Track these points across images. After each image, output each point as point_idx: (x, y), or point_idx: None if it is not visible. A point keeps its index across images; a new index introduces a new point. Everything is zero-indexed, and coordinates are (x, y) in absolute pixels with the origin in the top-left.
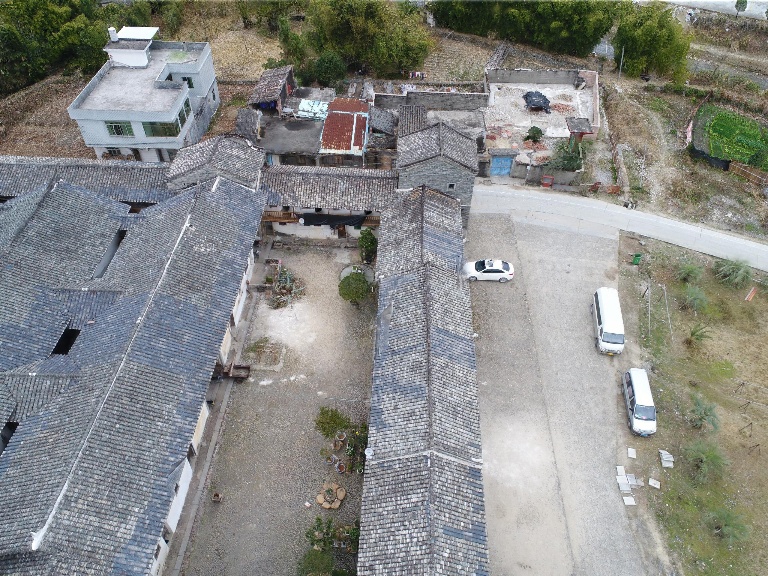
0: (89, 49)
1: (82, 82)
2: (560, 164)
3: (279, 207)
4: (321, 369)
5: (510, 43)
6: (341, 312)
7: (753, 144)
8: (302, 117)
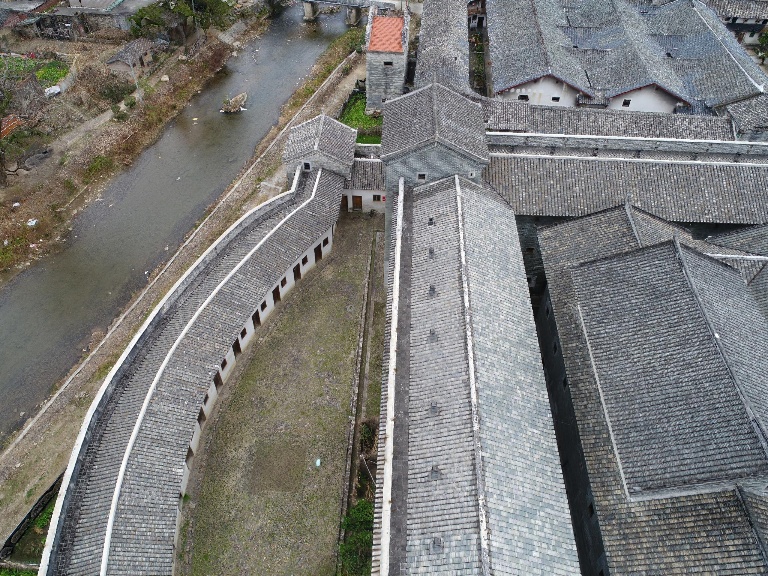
0: None
1: None
2: None
3: None
4: None
5: None
6: None
7: None
8: None
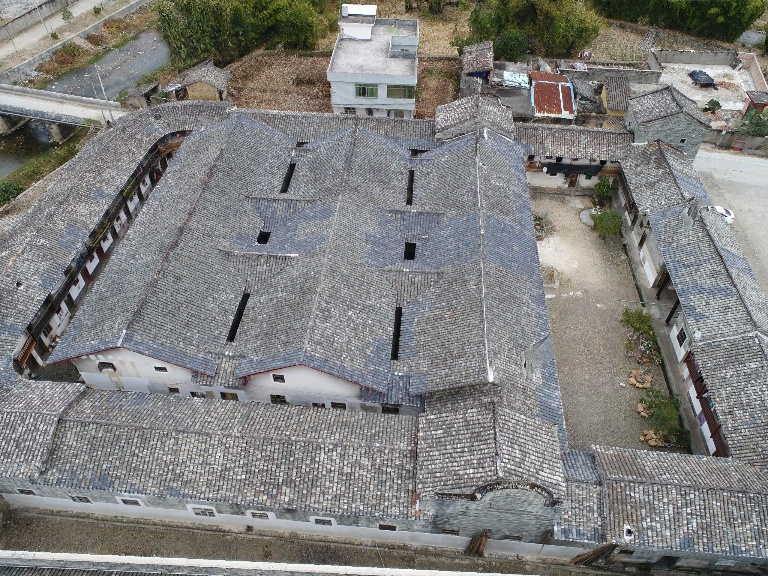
0: (291, 26)
1: (284, 56)
2: (751, 130)
3: (525, 157)
4: (592, 288)
5: (659, 29)
6: (592, 245)
7: None
8: (509, 86)
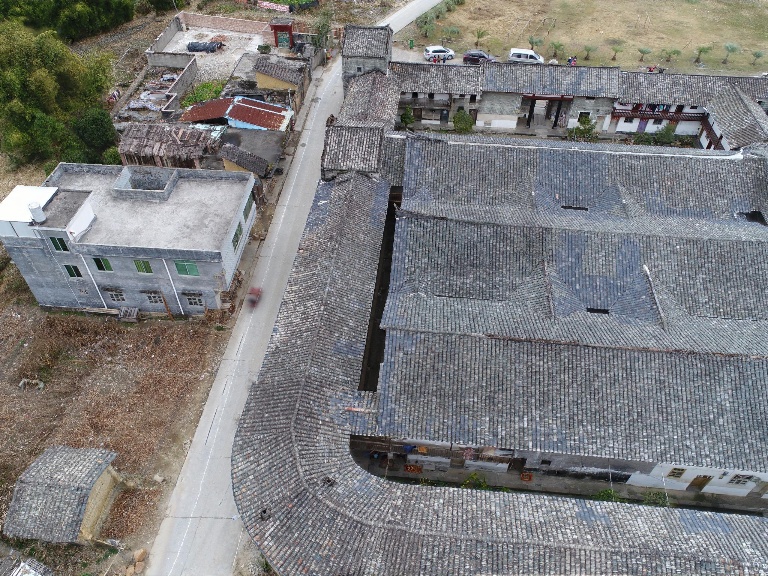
0: None
1: None
2: None
3: None
4: None
5: (74, 45)
6: None
7: None
8: None
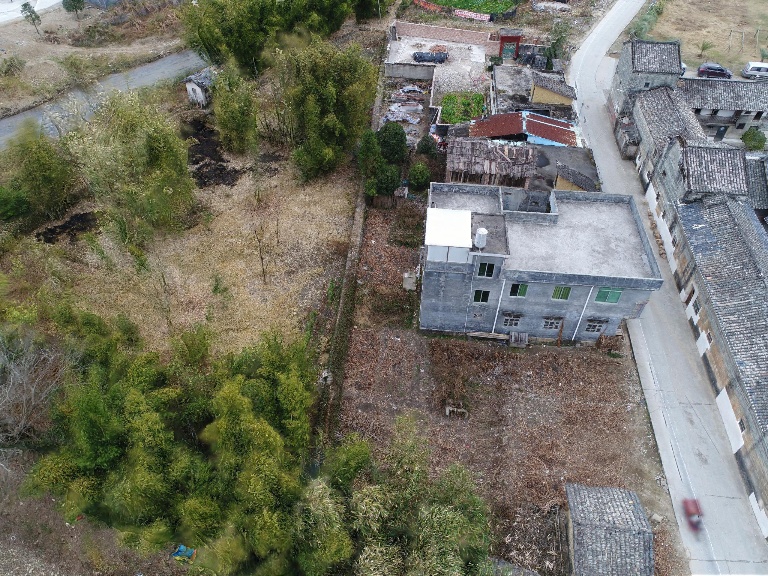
0: None
1: (343, 435)
2: None
3: None
4: None
5: None
6: None
7: (482, 1)
8: None
